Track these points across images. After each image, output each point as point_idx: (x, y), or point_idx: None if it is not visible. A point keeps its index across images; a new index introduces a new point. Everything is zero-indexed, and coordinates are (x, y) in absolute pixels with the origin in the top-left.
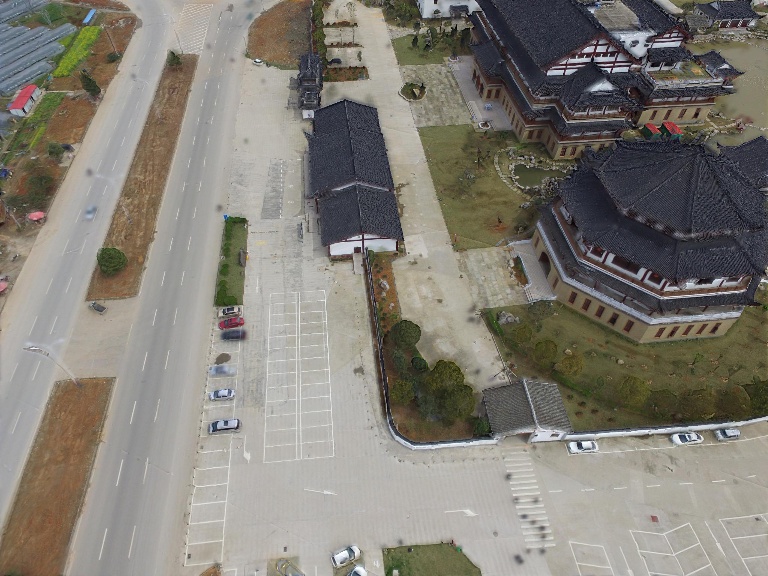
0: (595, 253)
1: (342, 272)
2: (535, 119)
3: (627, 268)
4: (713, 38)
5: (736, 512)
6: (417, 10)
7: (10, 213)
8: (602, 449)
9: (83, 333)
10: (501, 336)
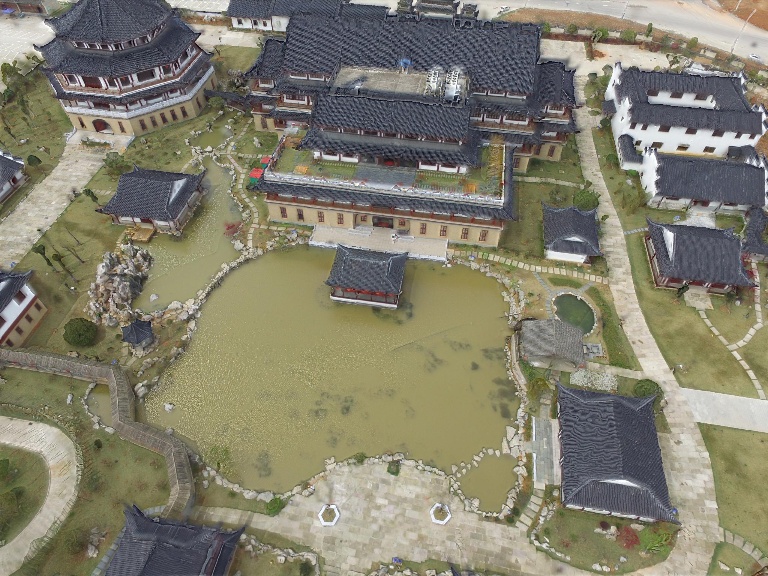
0: None
1: None
2: None
3: None
4: None
5: None
6: (605, 80)
7: None
8: None
9: None
10: None
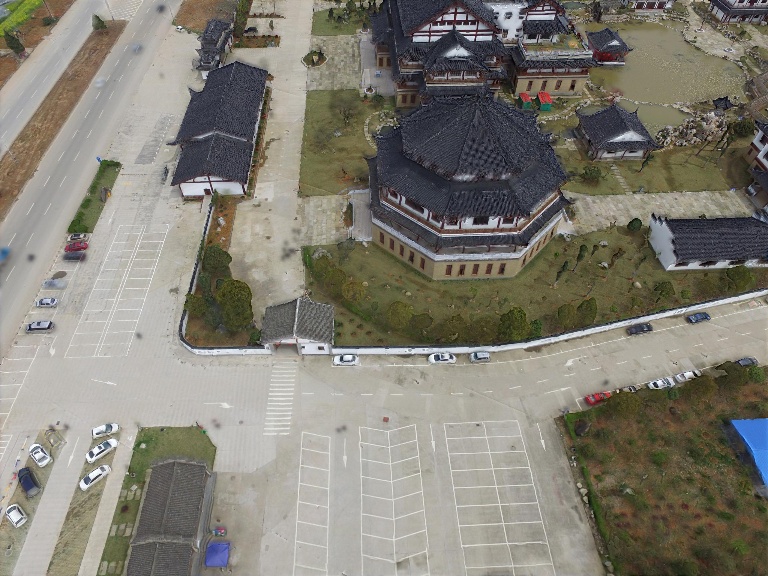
0: (392, 195)
1: (190, 210)
2: (406, 84)
3: (416, 208)
4: (627, 19)
5: (461, 418)
6: None
7: None
8: (364, 363)
9: None
10: (310, 268)
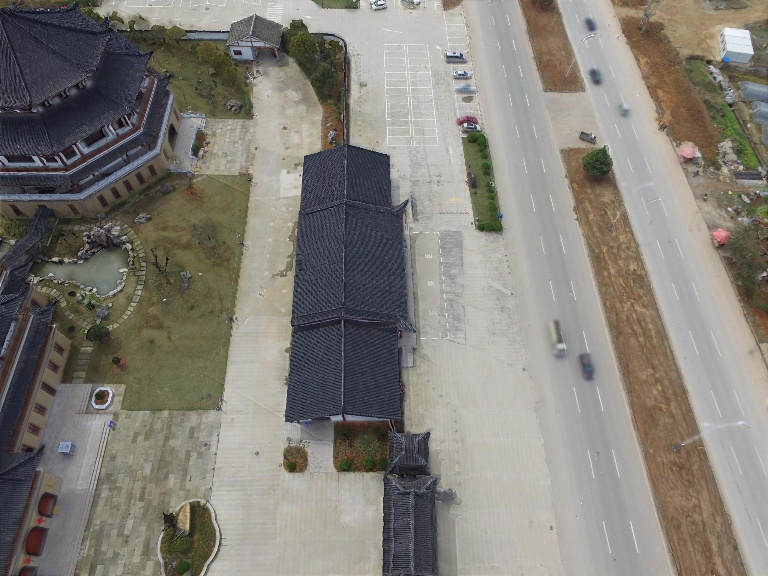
0: None
1: None
2: None
3: None
4: None
5: (160, 8)
6: None
7: (767, 263)
8: None
9: (588, 122)
10: None
